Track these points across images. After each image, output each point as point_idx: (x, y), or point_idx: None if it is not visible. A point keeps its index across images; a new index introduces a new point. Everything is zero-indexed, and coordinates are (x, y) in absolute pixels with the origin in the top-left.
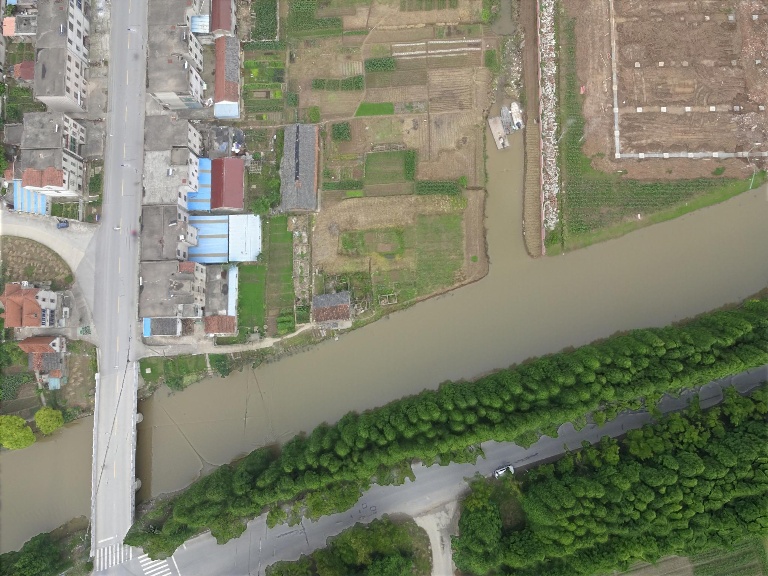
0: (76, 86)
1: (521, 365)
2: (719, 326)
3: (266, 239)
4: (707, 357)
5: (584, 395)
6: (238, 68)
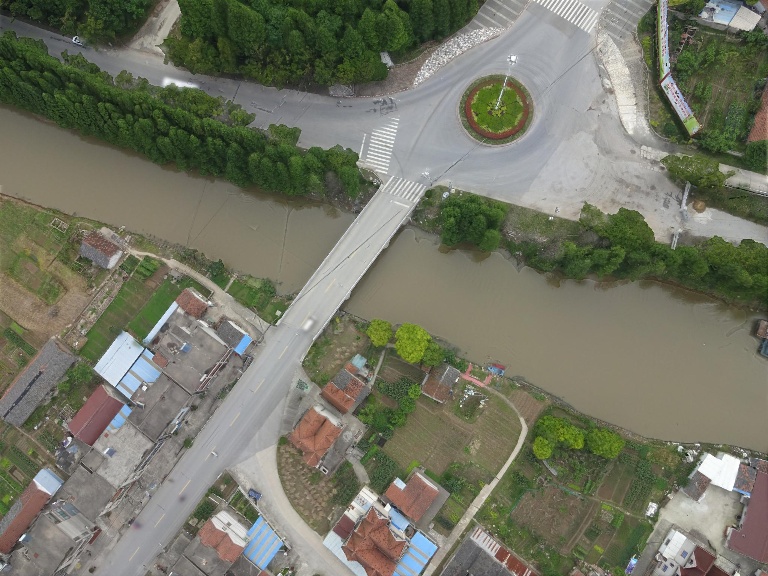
0: None
1: (4, 102)
2: None
3: None
4: None
5: None
6: None
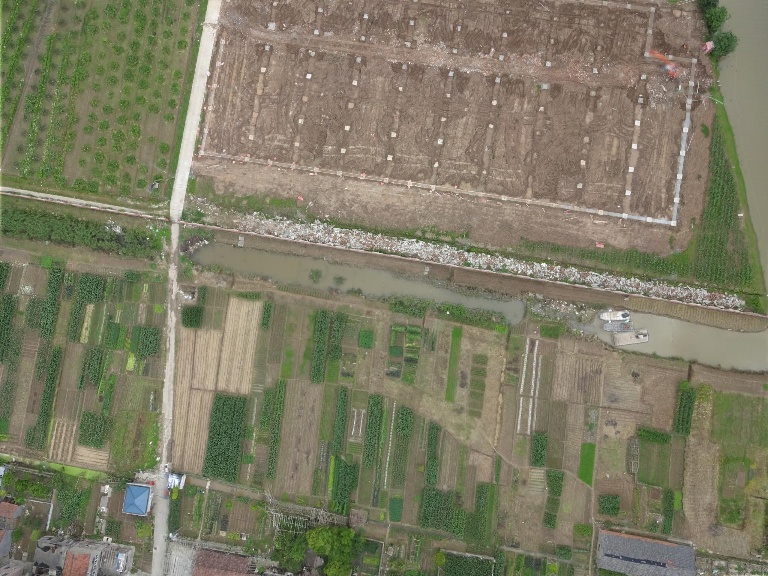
0: None
1: None
2: None
3: None
4: None
5: None
6: None
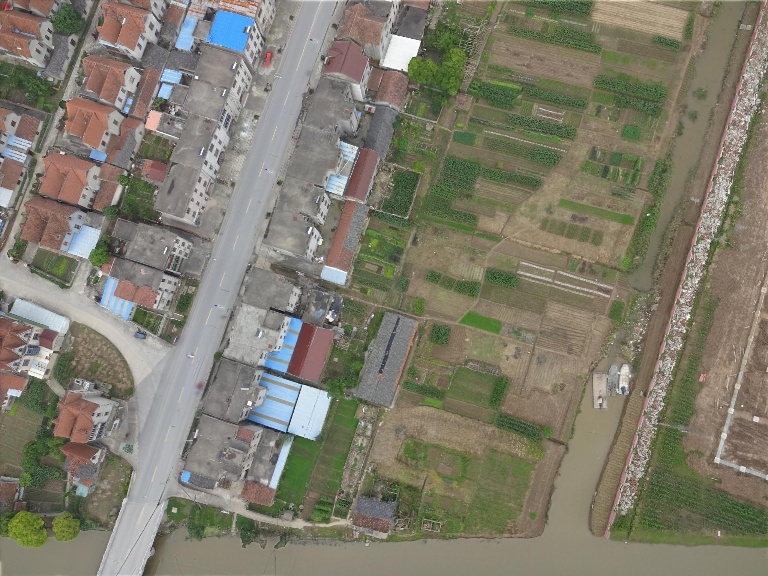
0: (197, 204)
1: None
2: None
3: (331, 418)
4: None
5: None
6: (359, 236)
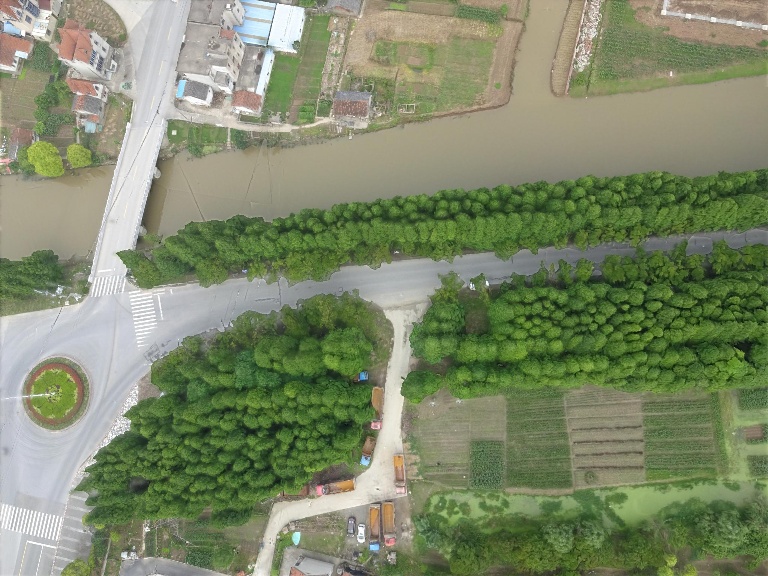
0: None
1: None
2: (724, 176)
3: (306, 34)
4: (702, 195)
5: (569, 203)
6: None
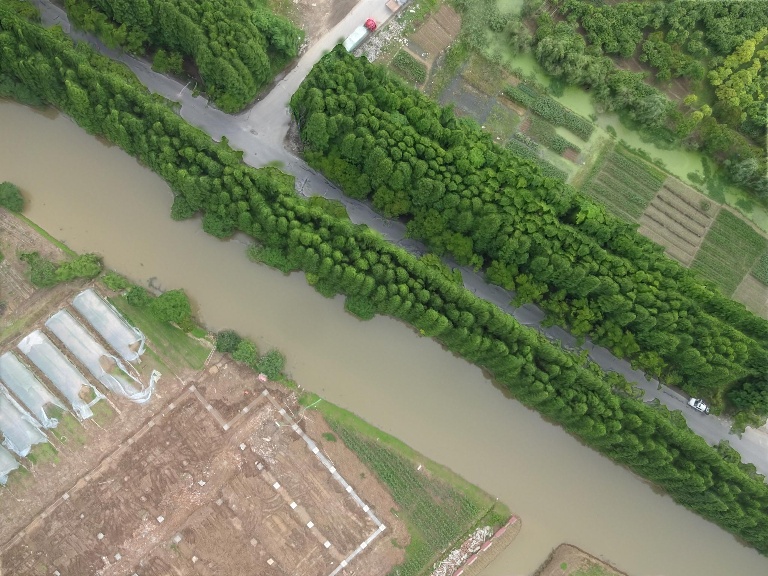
0: None
1: None
2: None
3: None
4: None
5: None
6: None
